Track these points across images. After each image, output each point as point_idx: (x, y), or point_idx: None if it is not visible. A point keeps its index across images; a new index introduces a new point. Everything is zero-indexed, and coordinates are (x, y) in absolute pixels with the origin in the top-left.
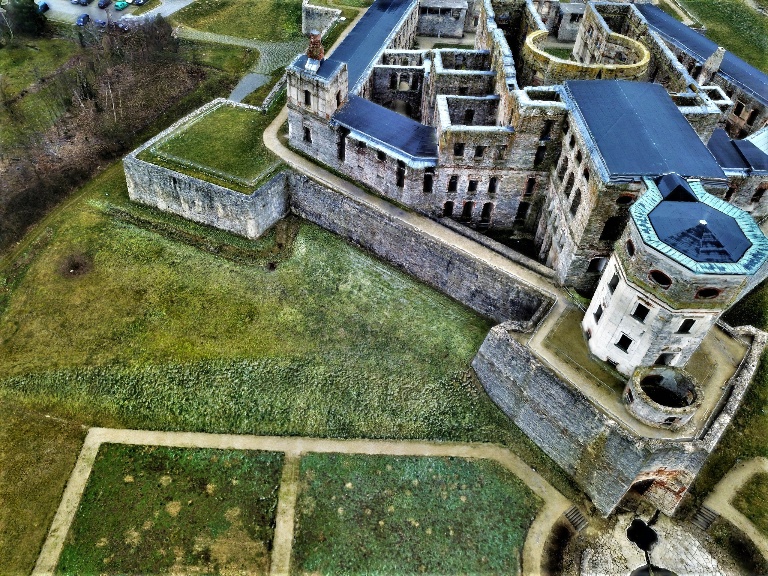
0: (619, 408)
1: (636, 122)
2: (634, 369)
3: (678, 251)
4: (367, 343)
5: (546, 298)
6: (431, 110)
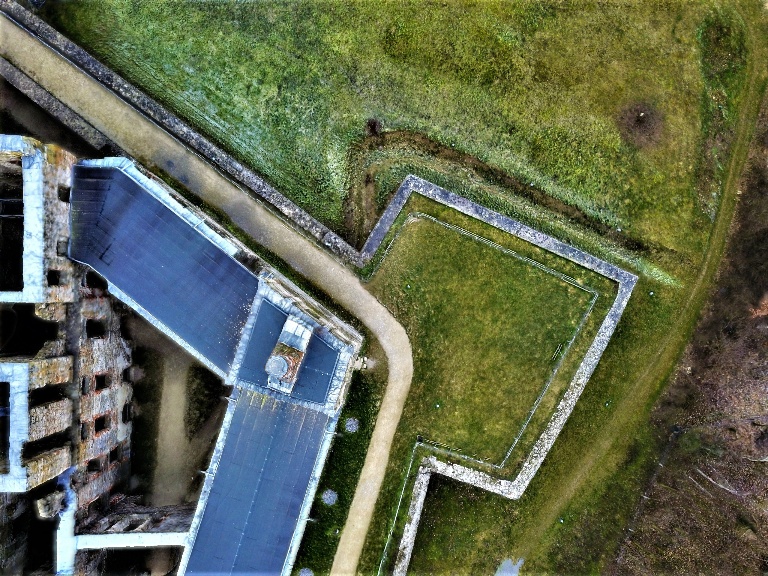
0: None
1: None
2: None
3: None
4: (239, 2)
5: None
6: (74, 344)
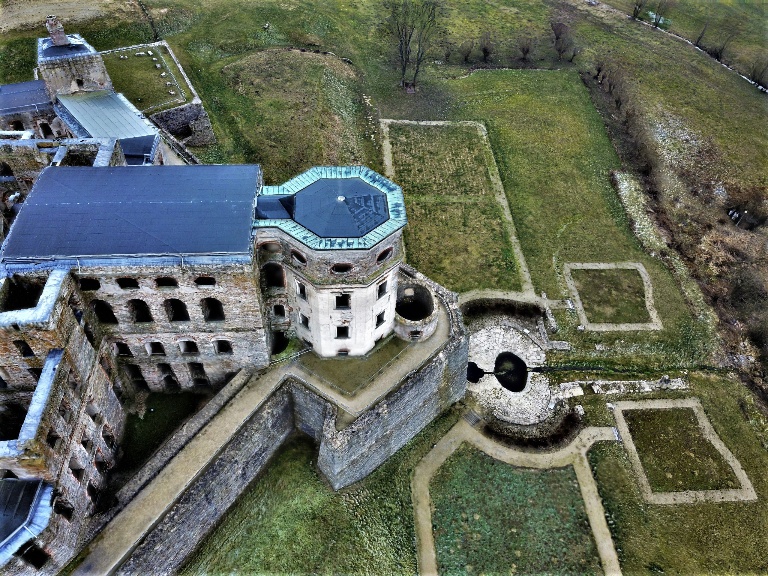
0: (421, 347)
1: (140, 207)
2: (394, 322)
3: (376, 228)
4: None
5: (291, 384)
6: None
